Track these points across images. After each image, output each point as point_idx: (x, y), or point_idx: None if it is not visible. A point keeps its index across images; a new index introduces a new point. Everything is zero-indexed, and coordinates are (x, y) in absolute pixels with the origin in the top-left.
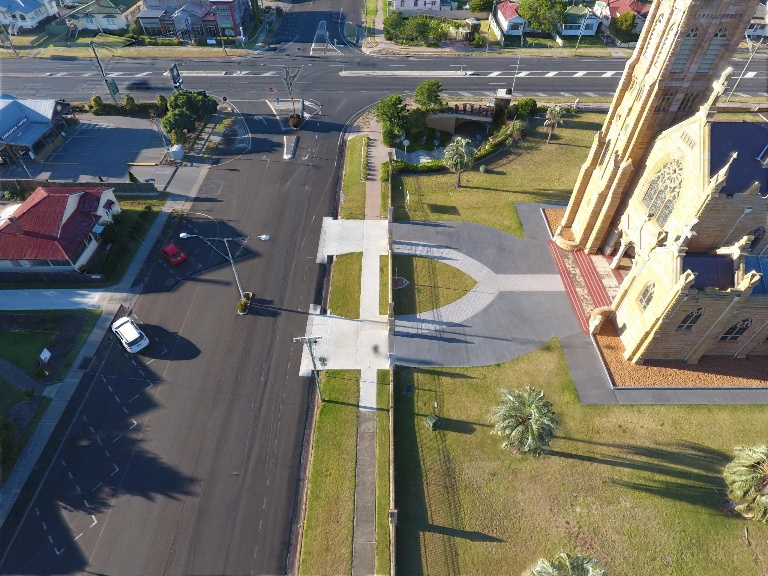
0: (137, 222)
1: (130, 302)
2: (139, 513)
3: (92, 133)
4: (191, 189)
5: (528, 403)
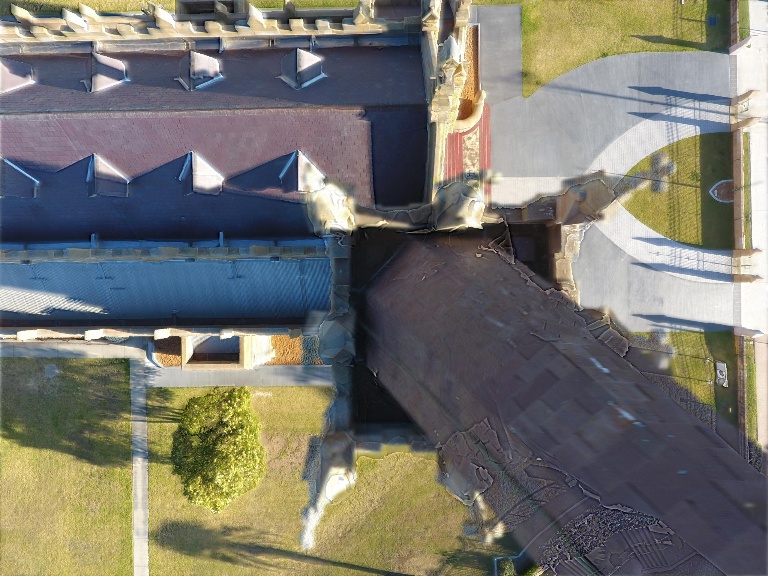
0: None
1: None
2: None
3: None
4: None
5: None
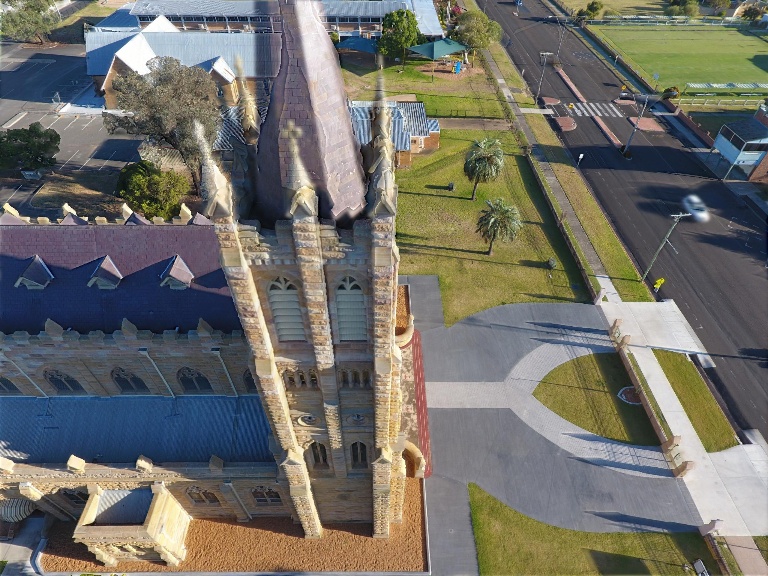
0: None
1: None
2: (709, 228)
3: None
4: None
5: (505, 207)
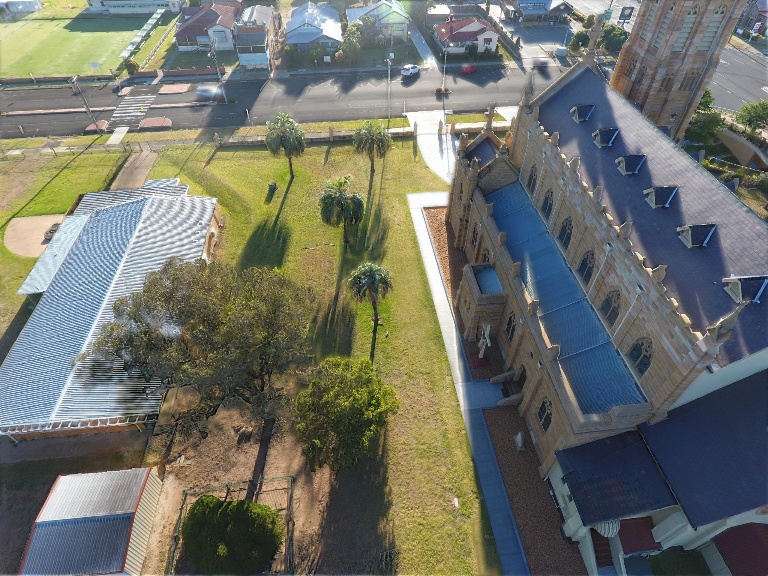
0: (486, 55)
1: (432, 69)
2: None
3: (562, 30)
4: (531, 65)
5: None
